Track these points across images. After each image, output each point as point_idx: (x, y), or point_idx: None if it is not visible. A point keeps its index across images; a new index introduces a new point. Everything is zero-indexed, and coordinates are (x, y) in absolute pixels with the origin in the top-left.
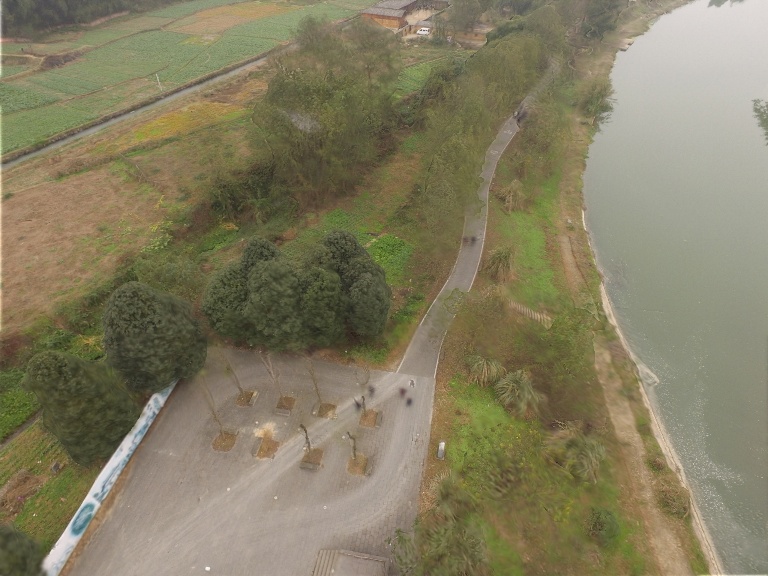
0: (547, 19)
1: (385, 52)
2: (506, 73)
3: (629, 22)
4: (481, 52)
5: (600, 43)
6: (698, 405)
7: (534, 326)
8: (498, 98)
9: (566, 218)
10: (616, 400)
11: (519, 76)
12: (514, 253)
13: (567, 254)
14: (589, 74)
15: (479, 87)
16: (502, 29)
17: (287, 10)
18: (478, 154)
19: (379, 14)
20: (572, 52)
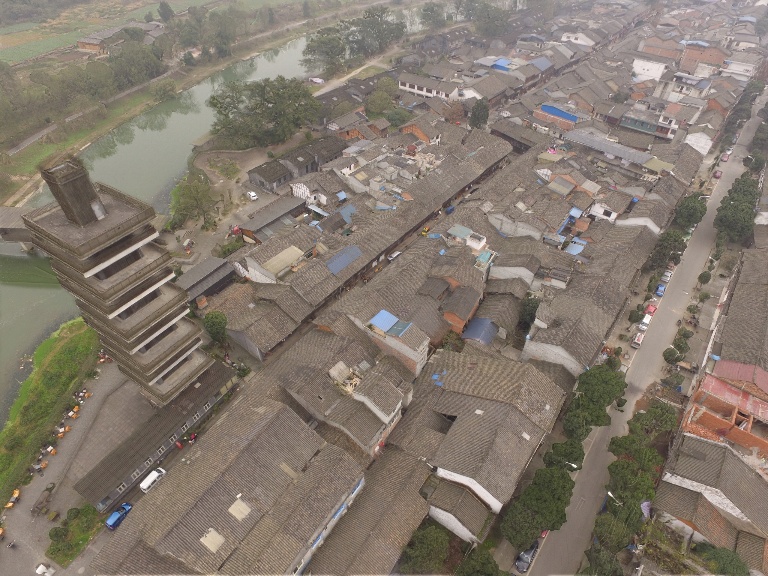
0: (129, 49)
1: (5, 72)
2: (67, 81)
3: (276, 40)
4: (34, 72)
5: (230, 56)
6: (45, 196)
7: (6, 179)
8: (39, 93)
9: (75, 146)
10: (15, 196)
11: (77, 82)
12: (6, 154)
13: (57, 158)
14: (192, 77)
15: (53, 88)
16: (122, 54)
17: (44, 38)
18: (7, 117)
19: (86, 42)
20: (162, 66)
